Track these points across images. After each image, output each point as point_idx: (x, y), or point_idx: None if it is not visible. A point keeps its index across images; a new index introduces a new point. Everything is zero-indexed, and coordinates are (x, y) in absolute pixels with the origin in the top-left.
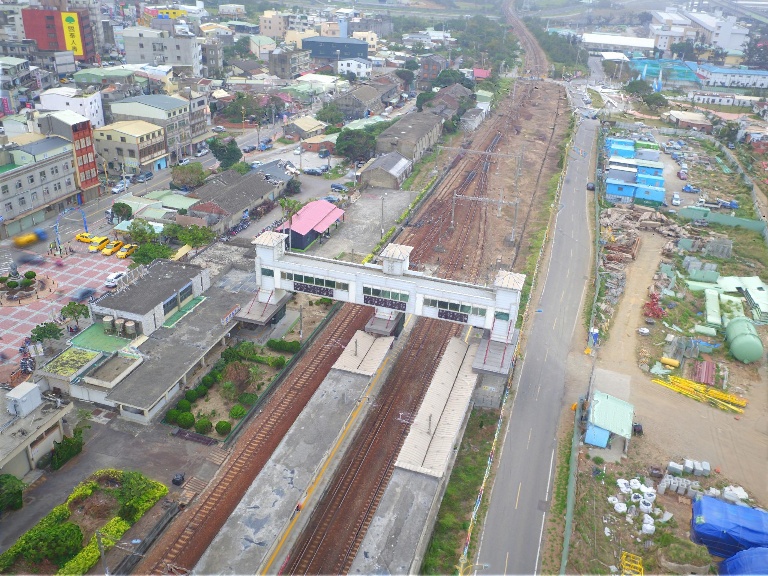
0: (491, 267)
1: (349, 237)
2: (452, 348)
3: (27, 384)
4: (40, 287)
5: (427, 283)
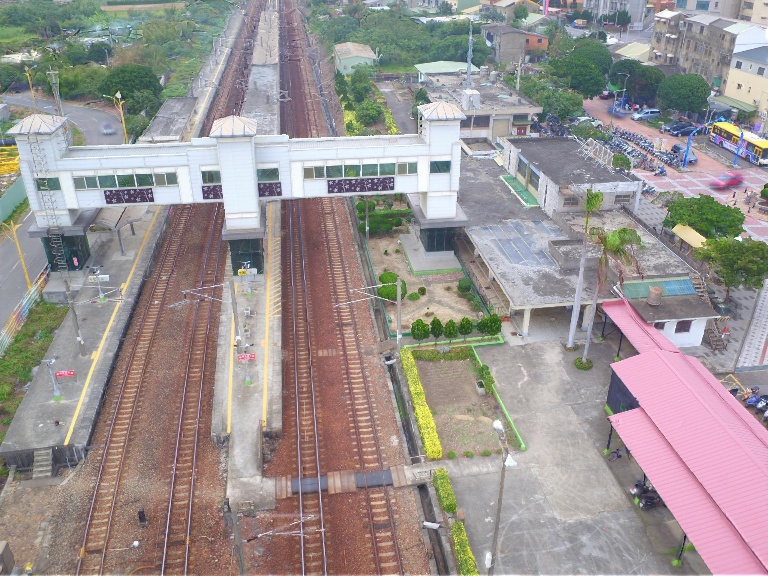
0: (33, 575)
1: (590, 533)
2: (140, 207)
3: (475, 93)
4: (765, 209)
5: (178, 152)
